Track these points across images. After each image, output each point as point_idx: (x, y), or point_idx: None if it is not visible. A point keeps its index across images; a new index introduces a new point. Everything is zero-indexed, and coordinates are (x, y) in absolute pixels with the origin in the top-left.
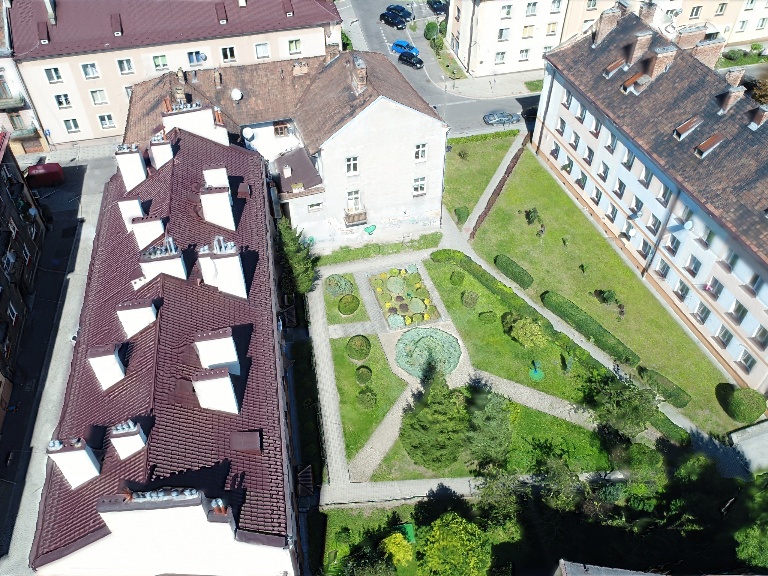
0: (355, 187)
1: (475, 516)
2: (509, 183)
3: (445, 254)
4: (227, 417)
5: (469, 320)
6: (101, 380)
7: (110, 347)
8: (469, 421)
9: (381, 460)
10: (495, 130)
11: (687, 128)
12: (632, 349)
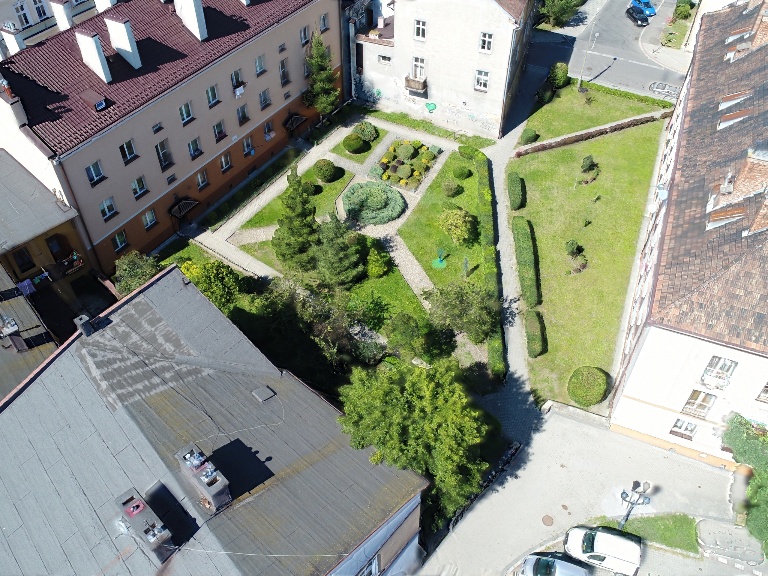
0: (421, 54)
1: (255, 291)
2: (606, 137)
3: (470, 150)
4: (97, 80)
5: (436, 203)
6: (60, 27)
7: (64, 0)
8: (318, 235)
9: (260, 241)
10: (648, 95)
11: (732, 98)
12: (549, 297)
